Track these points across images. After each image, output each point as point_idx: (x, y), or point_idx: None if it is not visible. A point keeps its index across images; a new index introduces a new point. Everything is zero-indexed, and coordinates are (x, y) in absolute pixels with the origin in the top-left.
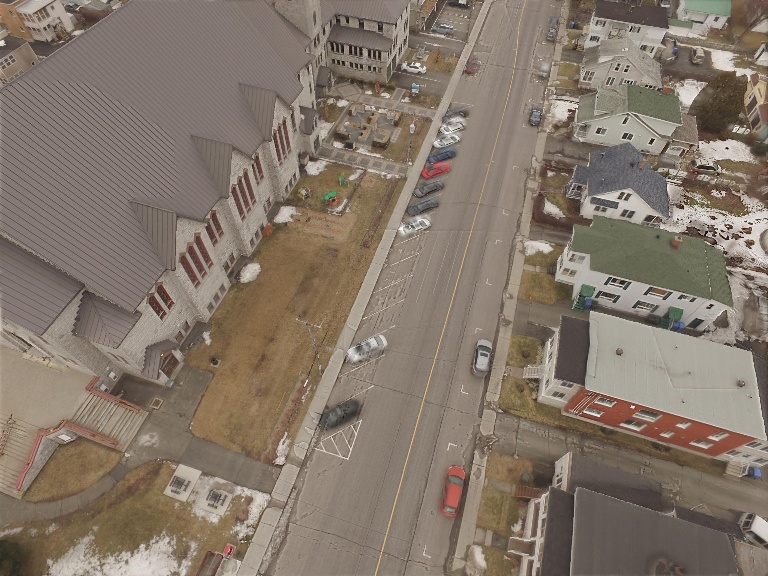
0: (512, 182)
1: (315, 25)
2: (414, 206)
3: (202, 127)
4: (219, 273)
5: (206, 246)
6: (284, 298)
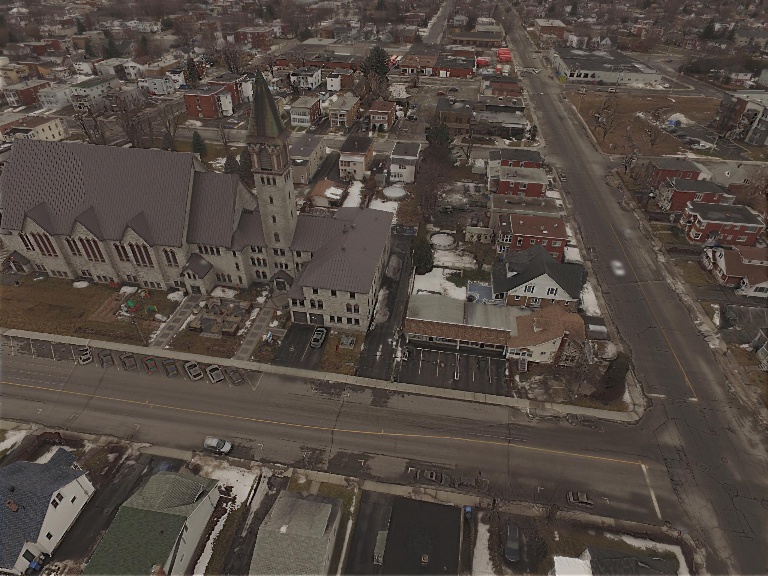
0: (115, 423)
1: (278, 242)
2: (110, 353)
3: (101, 208)
4: (64, 265)
5: (53, 245)
6: (50, 300)
